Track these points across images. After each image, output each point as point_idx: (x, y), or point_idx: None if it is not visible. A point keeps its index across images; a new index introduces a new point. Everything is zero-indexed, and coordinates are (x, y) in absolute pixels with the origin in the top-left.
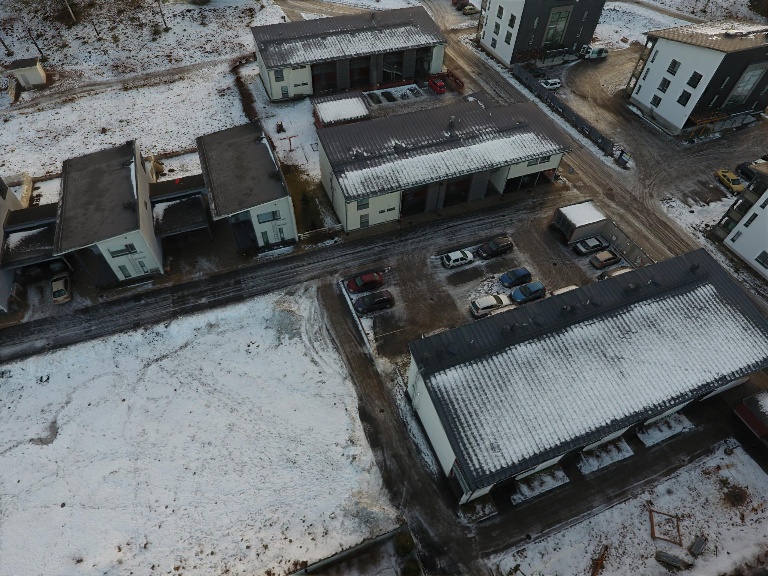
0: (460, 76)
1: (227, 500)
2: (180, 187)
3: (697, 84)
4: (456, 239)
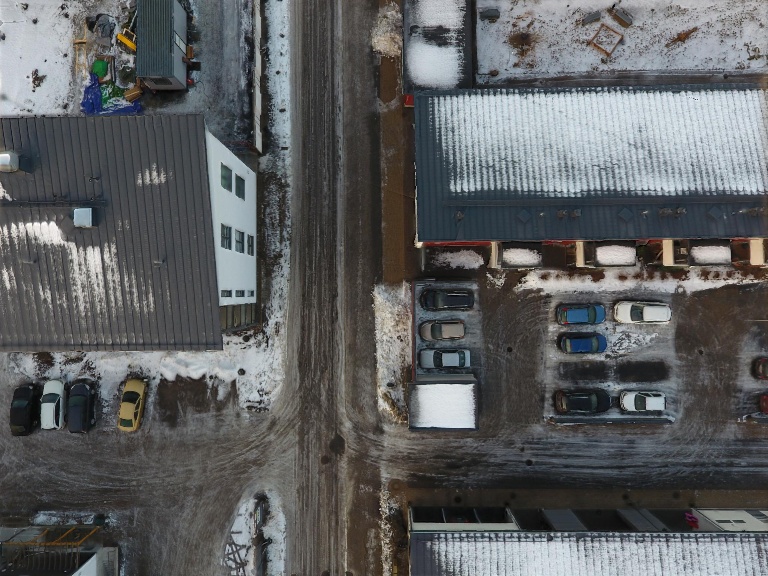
0: None
1: None
2: None
3: None
4: (623, 441)
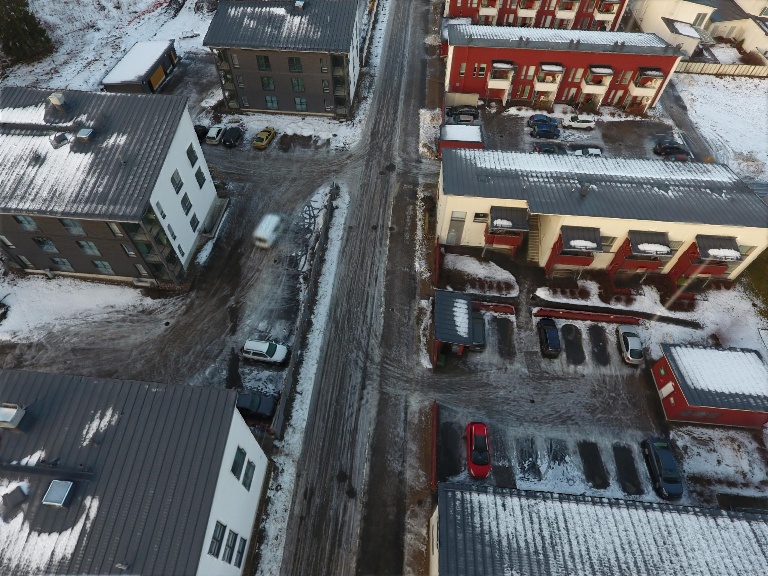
0: (396, 483)
1: (763, 104)
2: None
3: (193, 155)
4: None
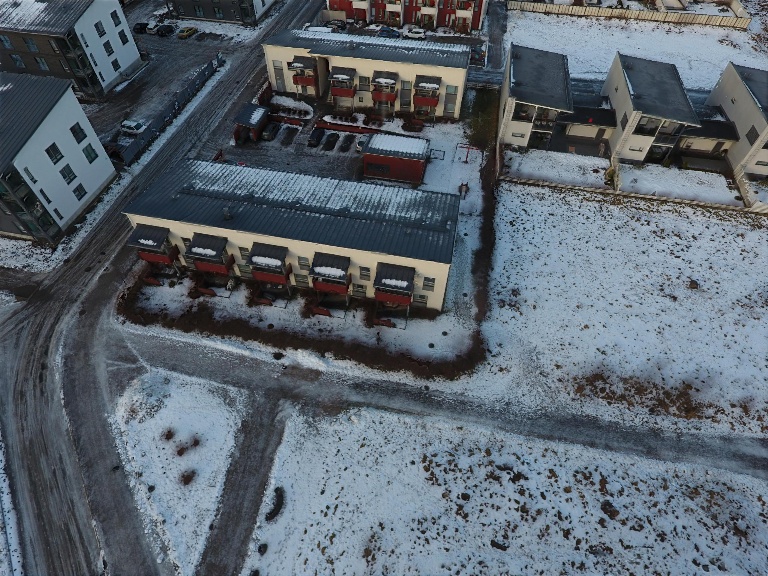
0: None
1: None
2: (588, 114)
3: (118, 20)
4: None
